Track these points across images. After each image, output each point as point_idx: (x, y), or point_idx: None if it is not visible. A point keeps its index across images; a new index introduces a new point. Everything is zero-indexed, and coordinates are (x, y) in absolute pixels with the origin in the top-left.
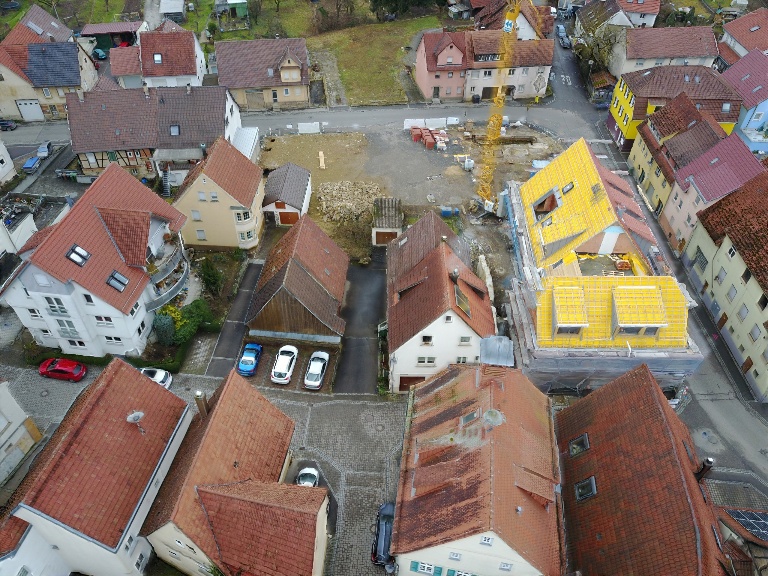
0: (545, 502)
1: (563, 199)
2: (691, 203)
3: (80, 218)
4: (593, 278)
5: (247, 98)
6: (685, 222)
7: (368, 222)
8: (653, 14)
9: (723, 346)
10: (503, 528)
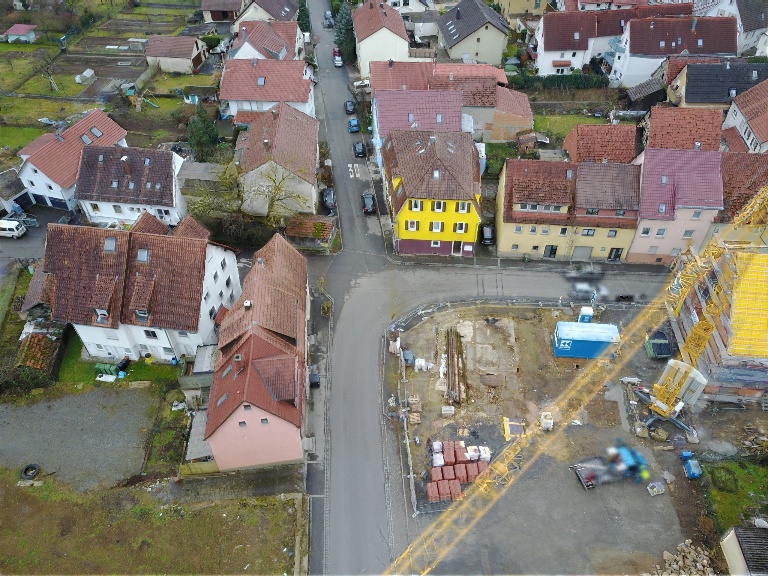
0: None
1: None
2: (689, 221)
3: None
4: None
5: None
6: (683, 239)
7: None
8: (124, 136)
9: None
10: None
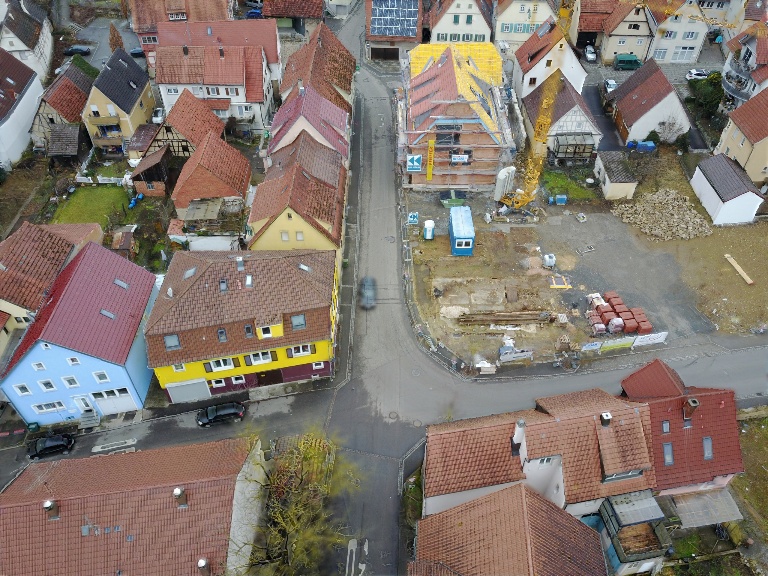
0: None
1: None
2: None
3: None
4: None
5: None
6: None
7: (634, 193)
8: None
9: (356, 119)
10: None
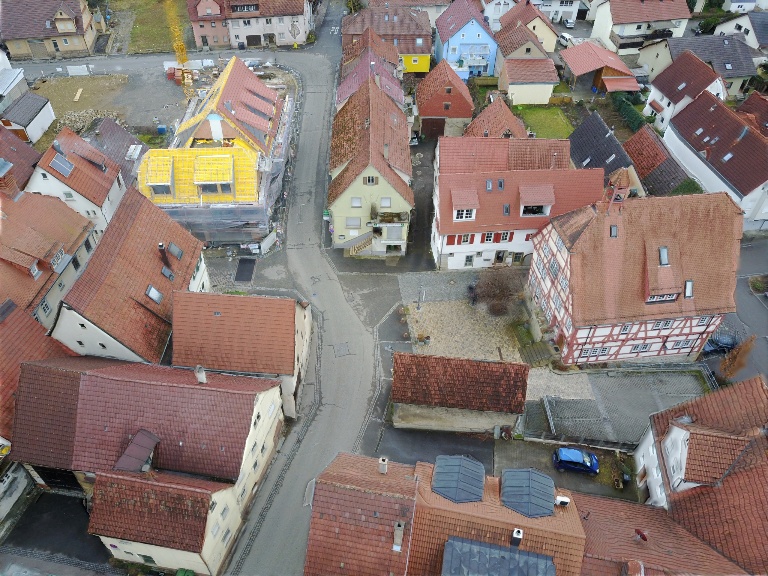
0: (27, 271)
1: (207, 103)
2: None
3: None
4: (180, 150)
5: (30, 48)
6: None
7: None
8: None
9: None
10: None
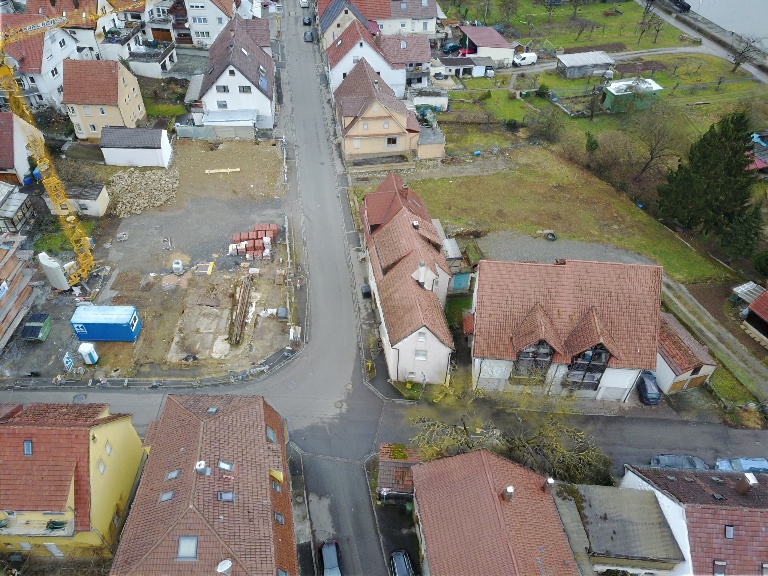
0: None
1: None
2: None
3: None
4: None
5: None
6: None
7: None
8: None
9: None
10: None
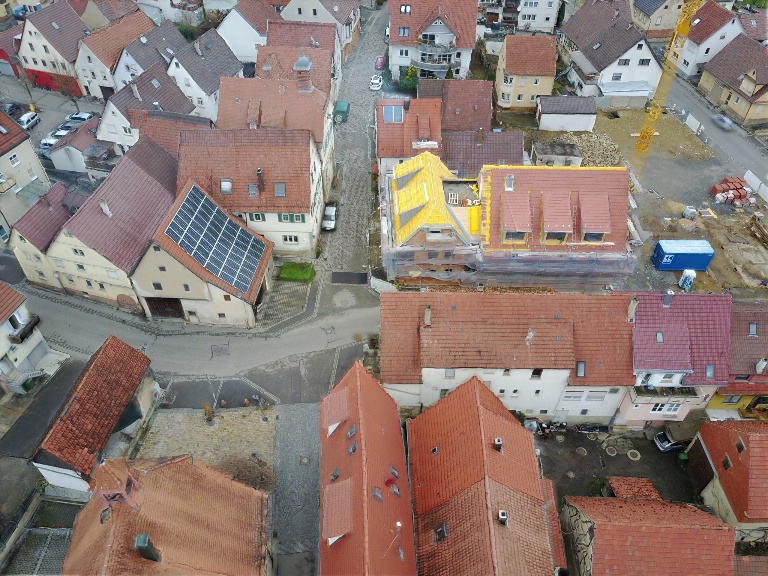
0: None
1: None
2: None
3: (428, 0)
4: None
5: (714, 87)
6: None
7: None
8: None
9: None
10: (226, 88)
